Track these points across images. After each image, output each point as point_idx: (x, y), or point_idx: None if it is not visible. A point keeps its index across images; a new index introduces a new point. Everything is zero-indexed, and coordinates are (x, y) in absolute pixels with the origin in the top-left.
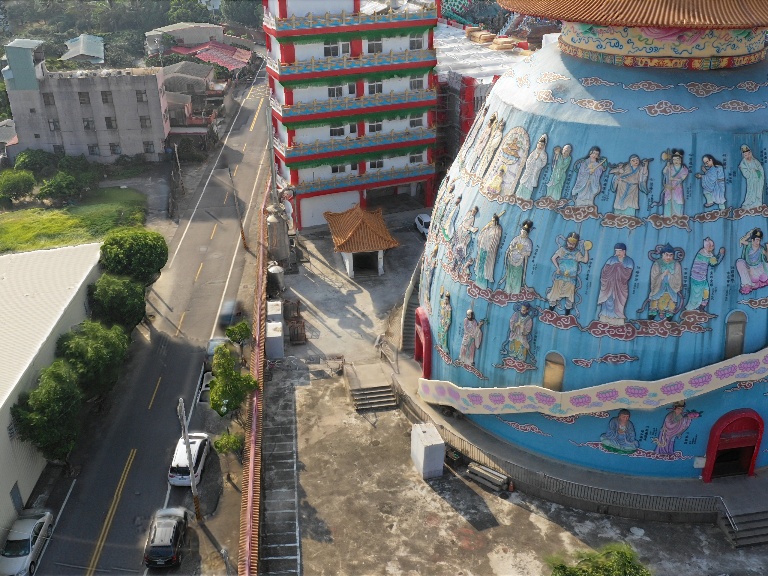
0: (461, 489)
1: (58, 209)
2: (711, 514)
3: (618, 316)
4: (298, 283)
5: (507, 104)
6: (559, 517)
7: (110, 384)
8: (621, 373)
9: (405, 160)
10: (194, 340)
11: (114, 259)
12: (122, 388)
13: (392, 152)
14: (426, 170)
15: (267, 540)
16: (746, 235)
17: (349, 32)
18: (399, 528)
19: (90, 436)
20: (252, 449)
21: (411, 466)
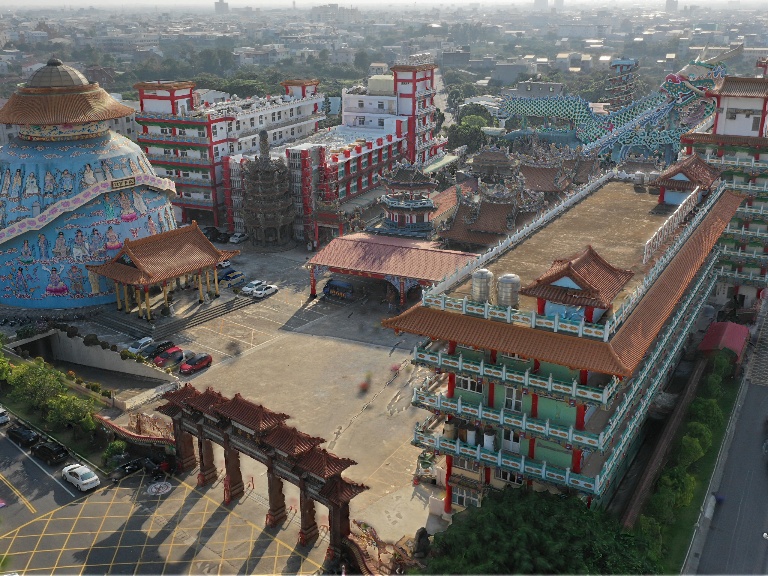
0: None
1: None
2: None
3: None
4: None
5: None
6: None
7: None
8: None
9: (200, 196)
10: None
11: None
12: None
13: (192, 189)
14: (208, 204)
15: None
16: None
17: (166, 123)
18: None
19: None
20: None
21: None
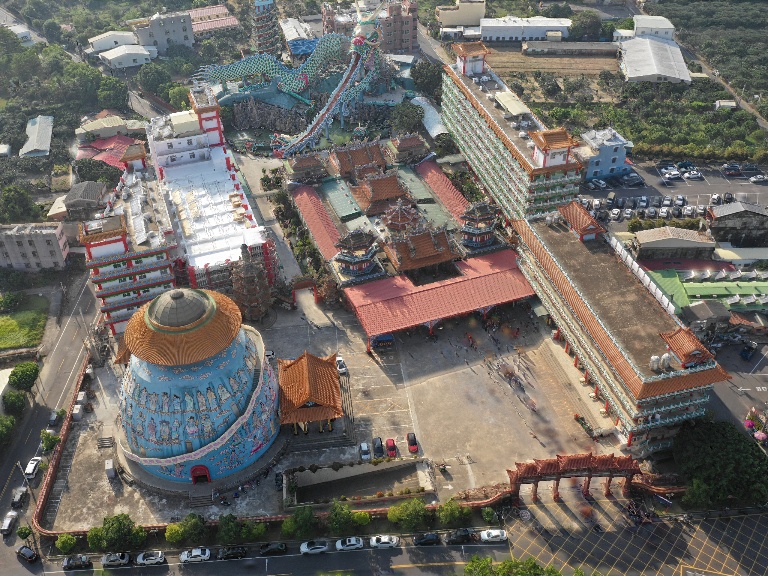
0: (119, 482)
1: (6, 315)
2: (188, 496)
3: (154, 438)
4: (102, 374)
5: None
6: (144, 494)
7: (8, 439)
8: (159, 453)
9: None
10: (49, 408)
11: (14, 382)
12: (18, 433)
13: None
14: None
15: (51, 499)
16: (188, 418)
17: (123, 260)
18: (93, 496)
19: (3, 455)
20: (50, 468)
21: None
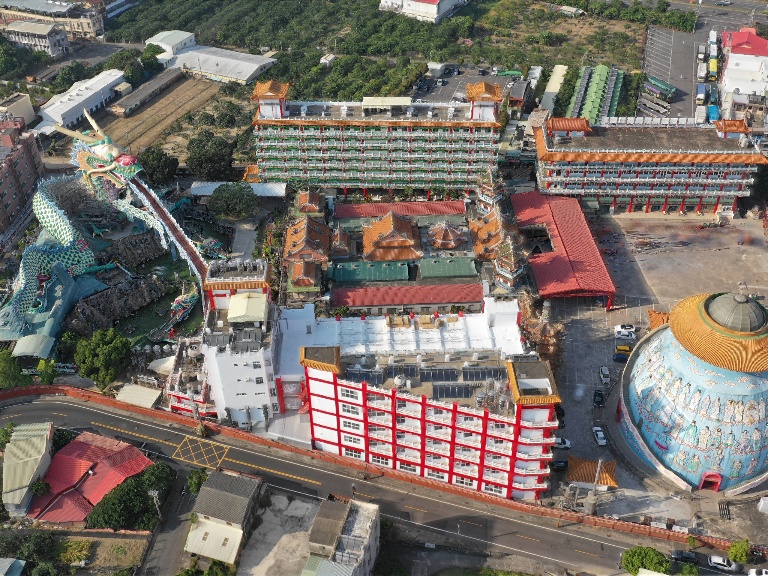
0: None
1: None
2: None
3: None
4: (608, 513)
5: (738, 395)
6: None
7: None
8: None
9: None
10: None
11: None
12: None
13: None
14: None
15: None
16: None
17: None
18: None
19: None
20: None
21: (766, 513)
